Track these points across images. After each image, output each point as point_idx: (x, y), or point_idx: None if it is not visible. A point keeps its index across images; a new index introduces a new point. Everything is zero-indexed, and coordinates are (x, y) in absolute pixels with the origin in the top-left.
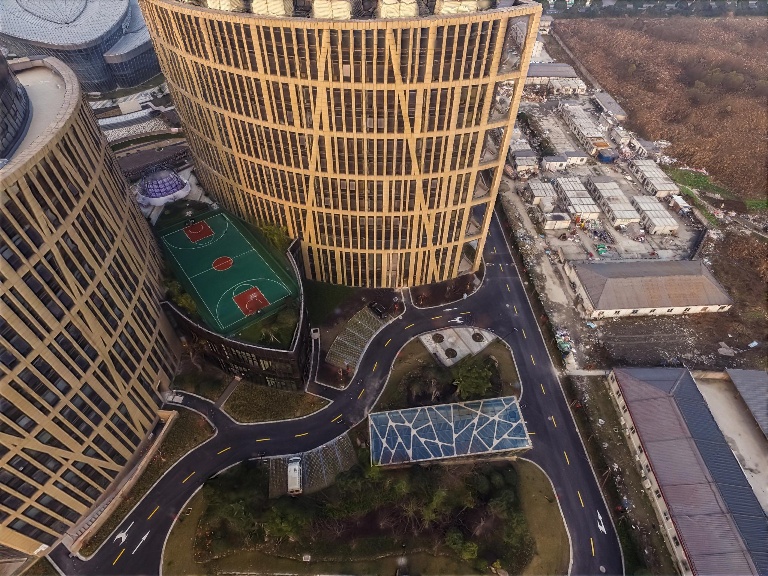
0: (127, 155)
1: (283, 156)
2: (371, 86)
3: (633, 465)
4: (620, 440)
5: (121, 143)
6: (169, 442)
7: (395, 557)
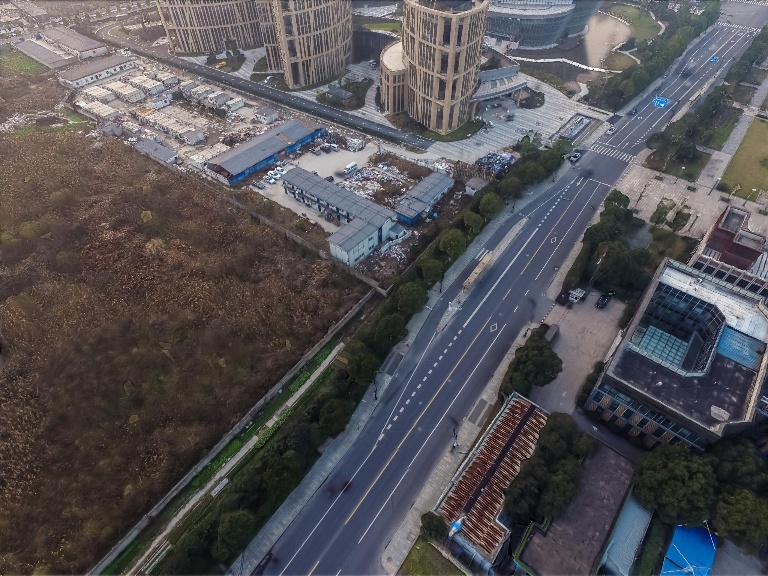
0: None
1: None
2: None
3: None
4: None
5: None
6: None
7: None
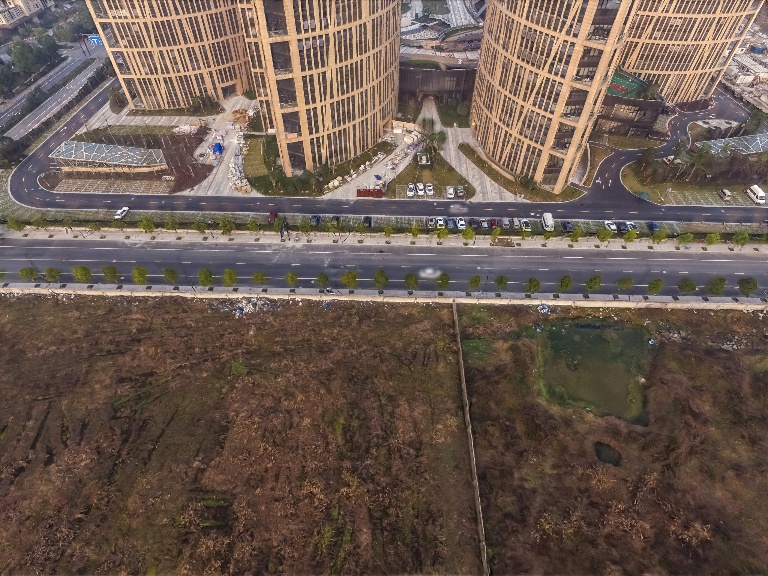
0: (466, 35)
1: (644, 4)
2: None
3: None
4: None
5: (454, 30)
6: (594, 153)
7: (741, 187)
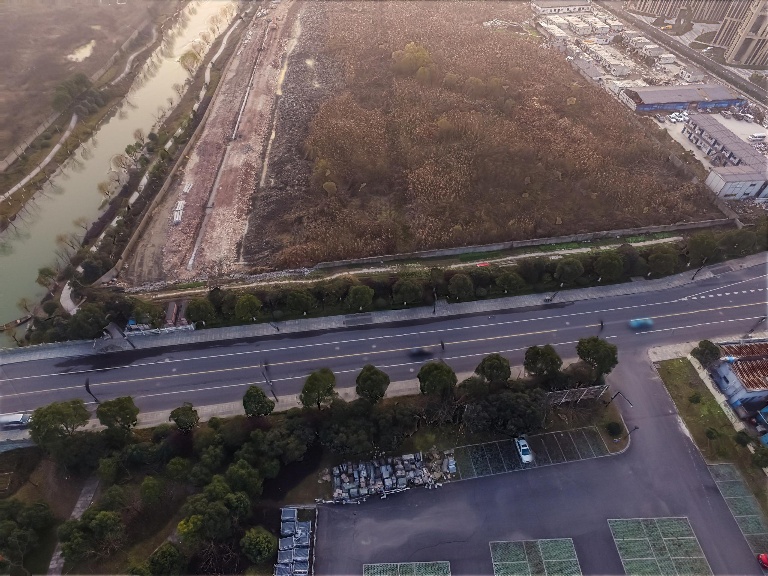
0: None
1: None
2: None
3: None
4: None
5: None
6: None
7: None
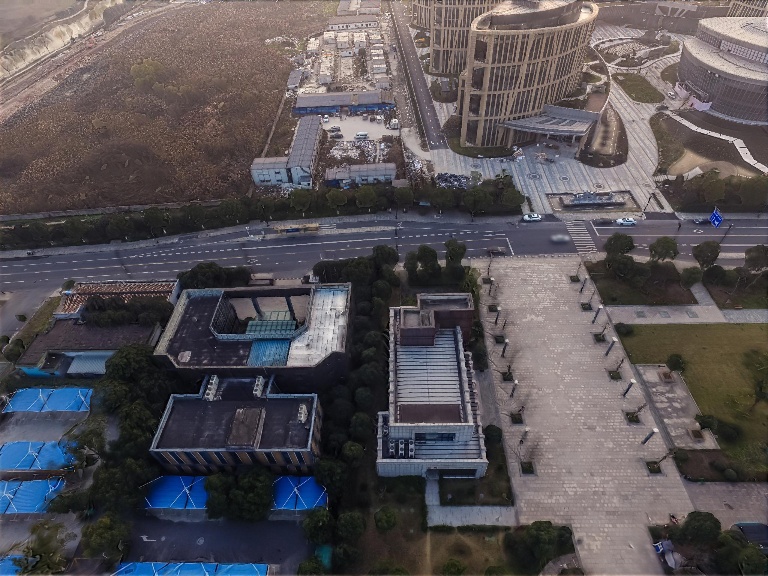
0: None
1: None
2: None
3: None
4: (382, 8)
5: None
6: None
7: None
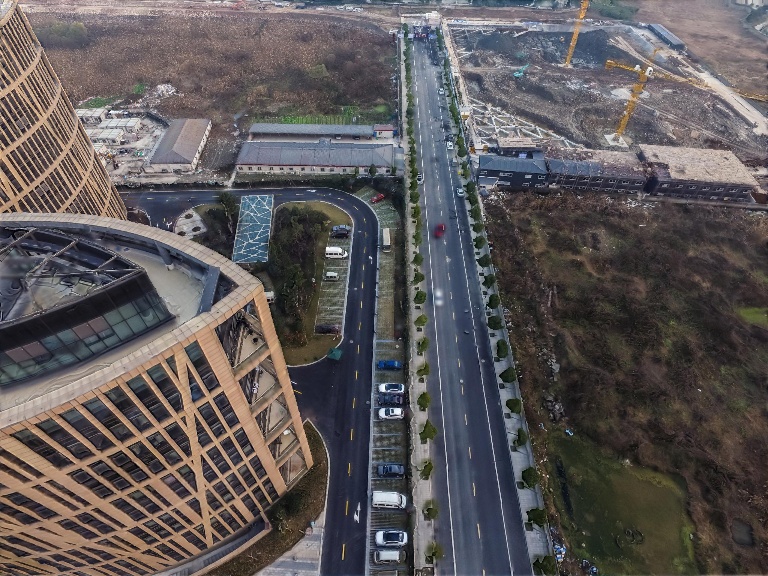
0: None
1: None
2: (1, 94)
3: (288, 176)
4: (274, 177)
5: None
6: None
7: (316, 258)
